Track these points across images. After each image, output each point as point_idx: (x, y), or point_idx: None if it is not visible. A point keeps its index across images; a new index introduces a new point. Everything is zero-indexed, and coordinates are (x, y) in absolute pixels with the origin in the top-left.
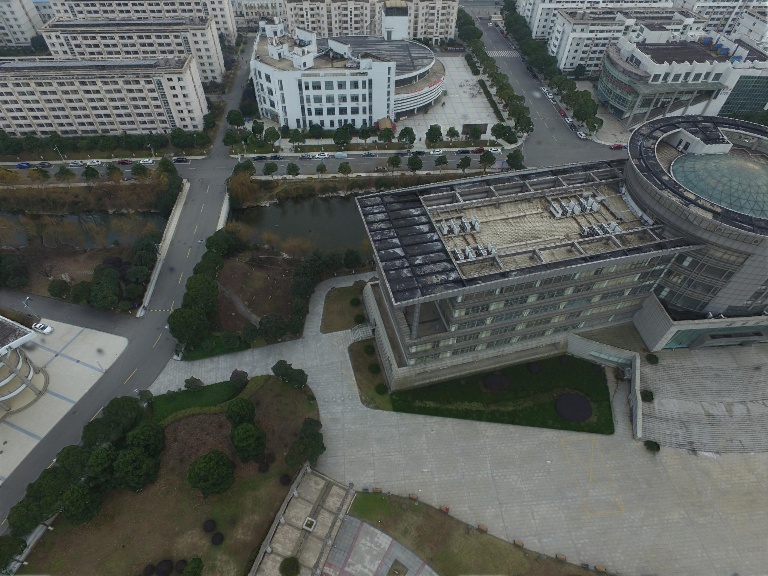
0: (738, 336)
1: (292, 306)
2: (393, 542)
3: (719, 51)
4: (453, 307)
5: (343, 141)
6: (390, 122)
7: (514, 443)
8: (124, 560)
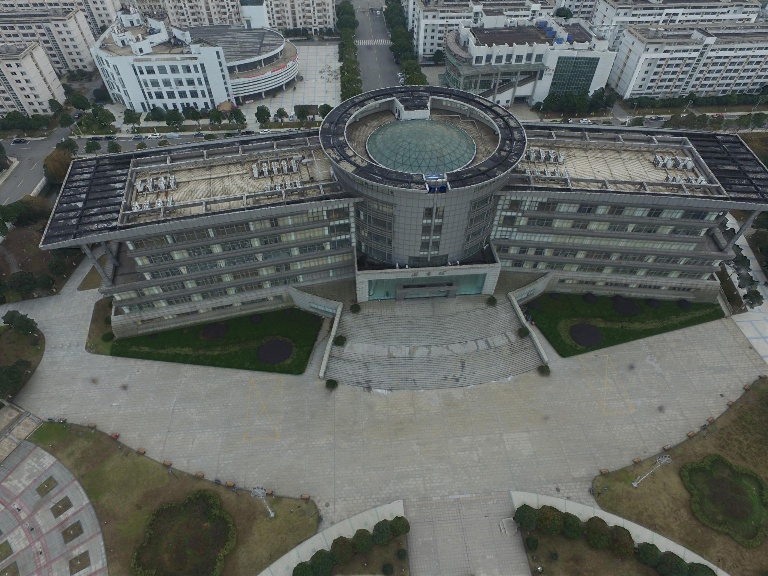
0: (430, 286)
1: (47, 265)
2: (56, 462)
3: (547, 34)
4: None
5: (175, 122)
6: (231, 105)
7: (207, 382)
8: None
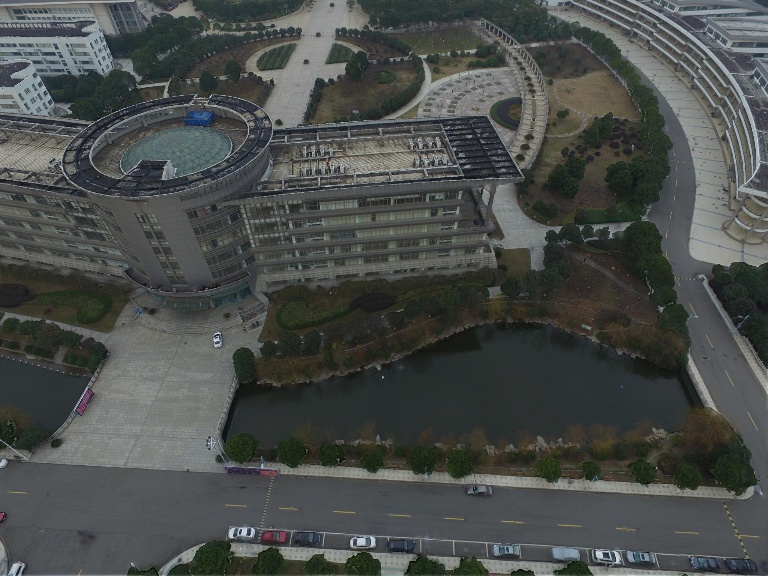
0: None
1: None
2: None
3: None
4: None
5: None
6: None
7: None
8: (601, 166)
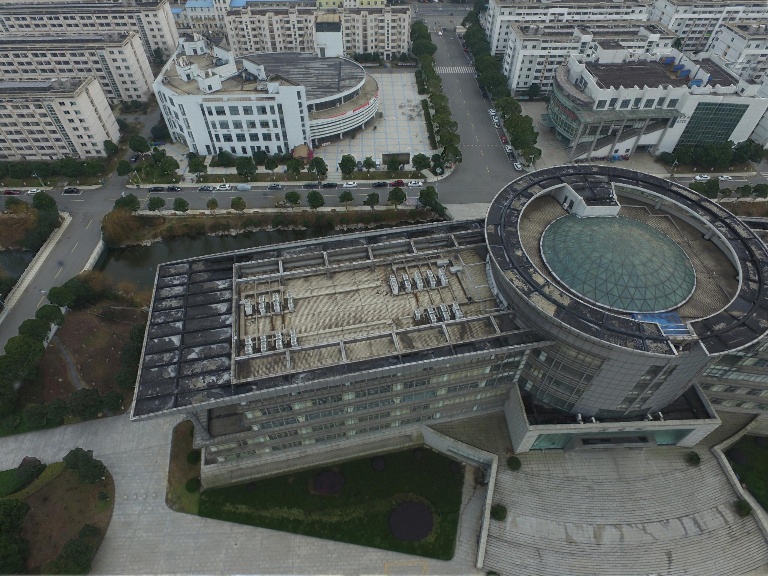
0: (618, 442)
1: (115, 377)
2: None
3: (679, 73)
4: (236, 410)
5: (247, 172)
6: (307, 149)
7: (328, 567)
8: None
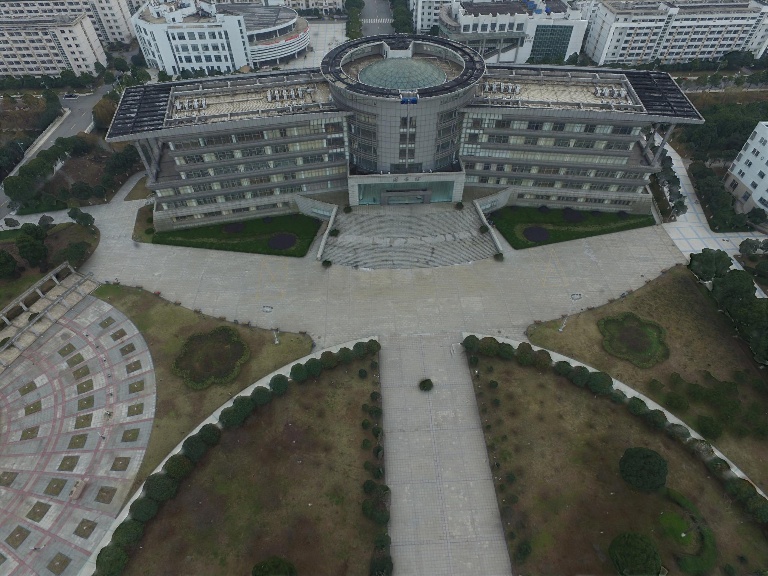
0: (408, 191)
1: None
2: (113, 308)
3: (528, 7)
4: None
5: None
6: (249, 68)
7: (228, 261)
8: None
